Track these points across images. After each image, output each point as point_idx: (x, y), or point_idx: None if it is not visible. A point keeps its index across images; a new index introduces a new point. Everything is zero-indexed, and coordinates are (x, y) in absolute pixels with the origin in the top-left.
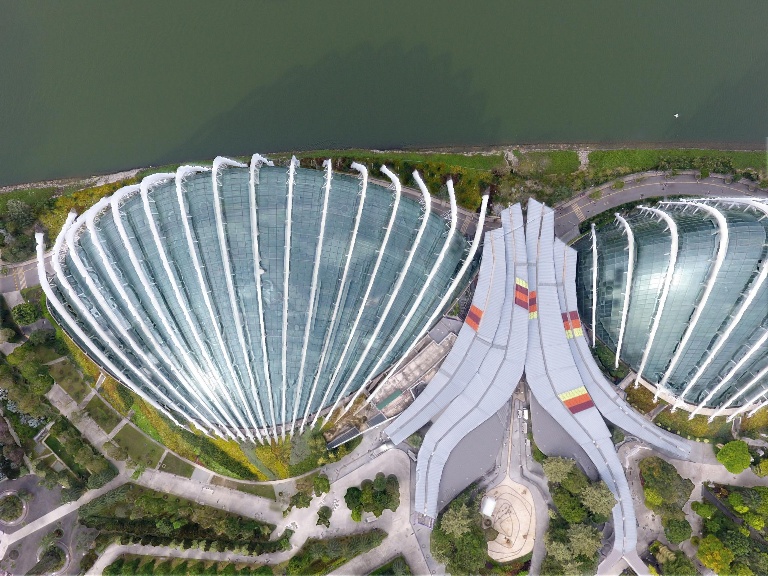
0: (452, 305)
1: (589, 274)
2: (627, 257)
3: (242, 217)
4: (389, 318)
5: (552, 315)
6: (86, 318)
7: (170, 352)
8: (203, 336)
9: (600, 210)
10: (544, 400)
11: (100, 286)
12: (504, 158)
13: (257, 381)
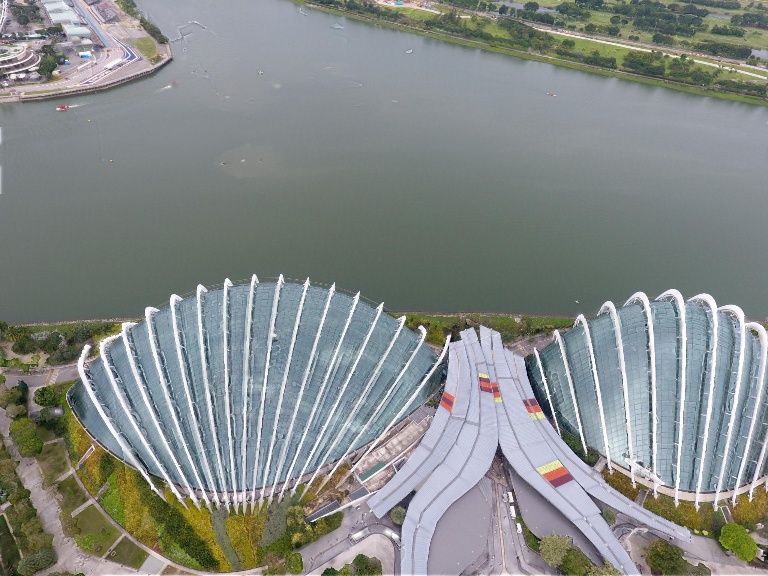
0: (428, 398)
1: (537, 370)
2: (559, 346)
3: (267, 304)
4: (374, 391)
5: (514, 400)
6: (105, 389)
7: (175, 406)
8: (211, 388)
9: (539, 349)
10: (523, 472)
11: (134, 356)
12: (460, 318)
13: (248, 435)
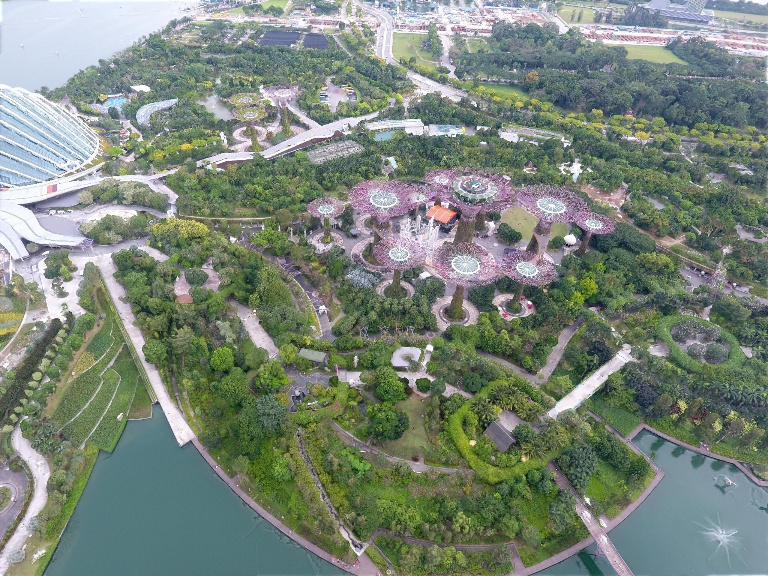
0: None
1: None
2: None
3: None
4: None
5: None
6: None
7: None
8: None
9: None
10: (41, 199)
11: None
12: None
13: None
